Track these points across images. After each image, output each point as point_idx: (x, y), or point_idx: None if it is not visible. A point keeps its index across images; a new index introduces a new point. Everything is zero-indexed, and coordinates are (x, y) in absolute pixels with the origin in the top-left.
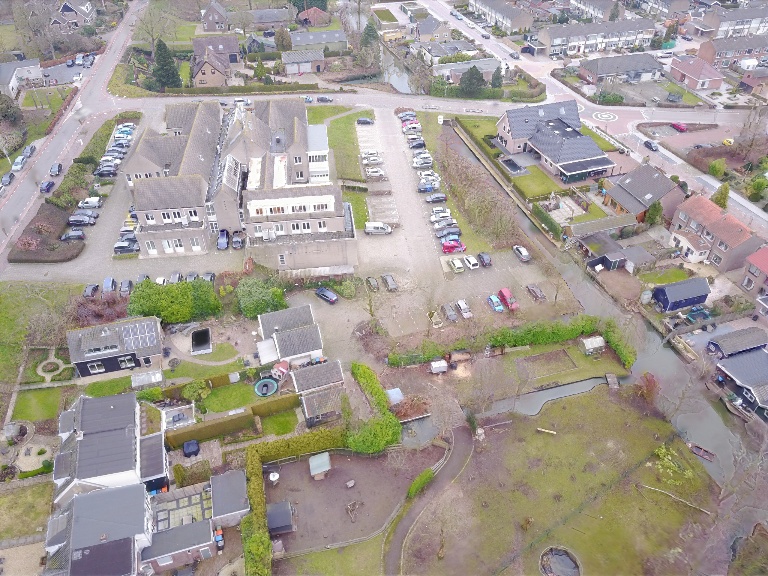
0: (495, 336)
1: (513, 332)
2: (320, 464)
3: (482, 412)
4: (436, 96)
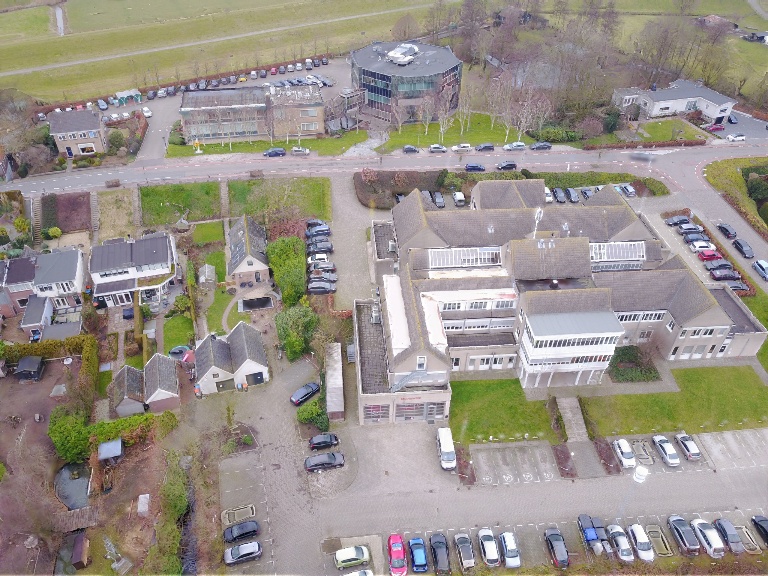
0: (144, 567)
1: None
2: (61, 390)
3: (50, 543)
4: None
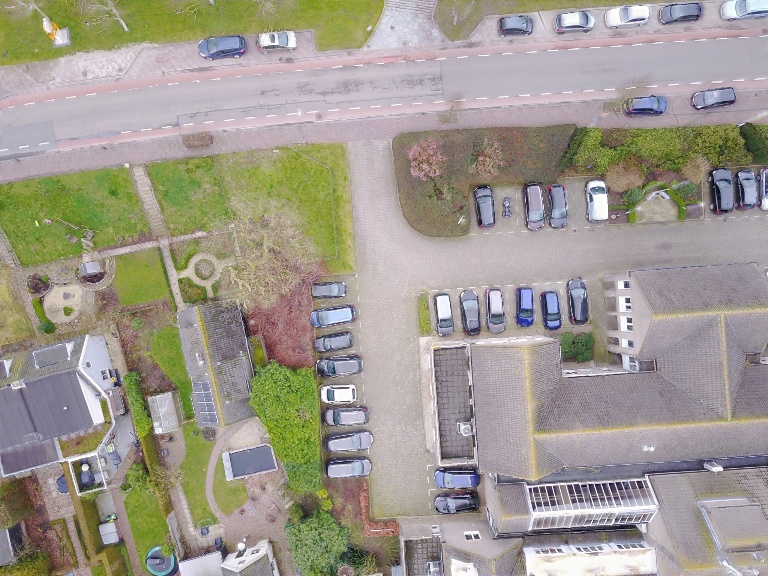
0: None
1: None
2: None
3: None
4: None
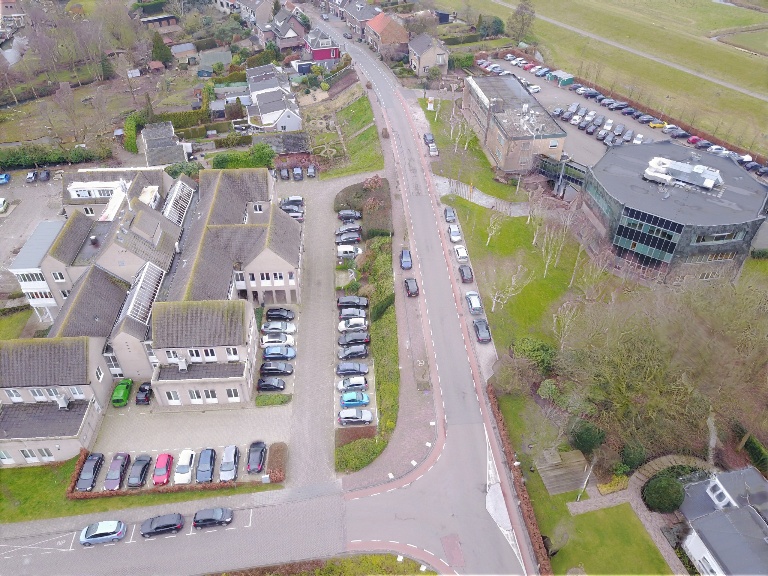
0: (33, 143)
1: (16, 154)
2: None
3: None
4: None
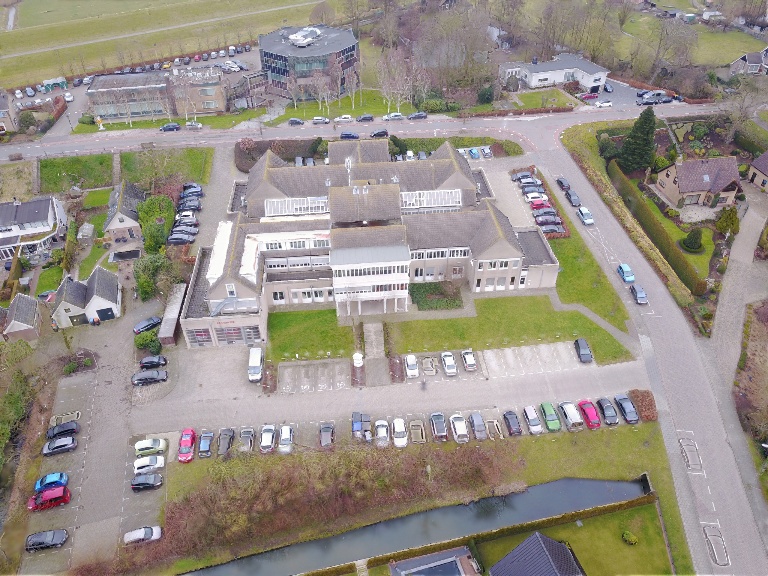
0: None
1: None
2: None
3: None
4: (766, 470)
